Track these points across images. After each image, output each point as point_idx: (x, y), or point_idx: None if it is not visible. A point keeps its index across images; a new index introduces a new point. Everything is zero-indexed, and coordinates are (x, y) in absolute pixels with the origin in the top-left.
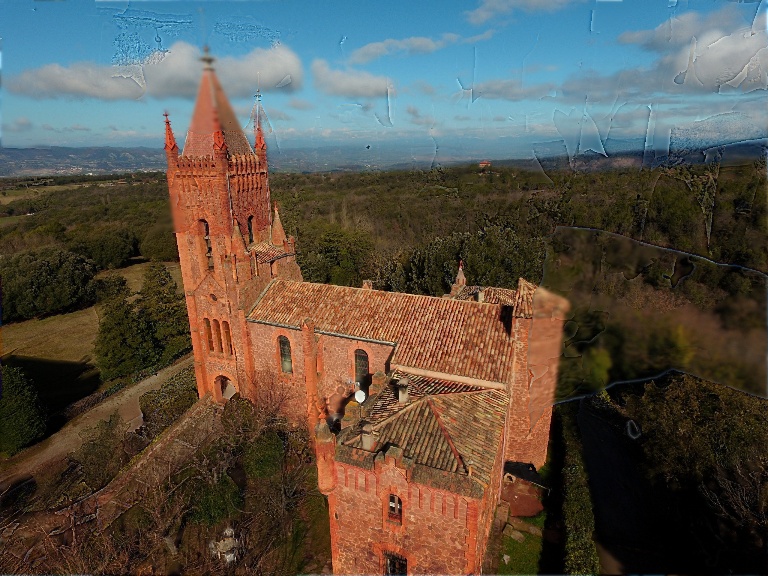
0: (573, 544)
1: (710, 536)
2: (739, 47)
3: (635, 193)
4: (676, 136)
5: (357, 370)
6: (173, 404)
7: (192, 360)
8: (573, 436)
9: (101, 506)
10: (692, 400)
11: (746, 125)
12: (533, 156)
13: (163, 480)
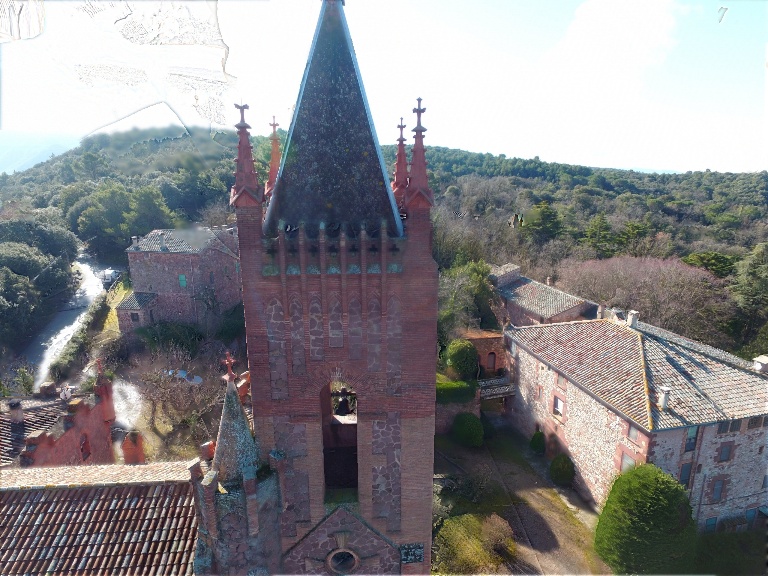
0: None
1: None
2: None
3: None
4: None
5: None
6: None
7: None
8: None
9: None
10: None
11: None
12: None
13: None
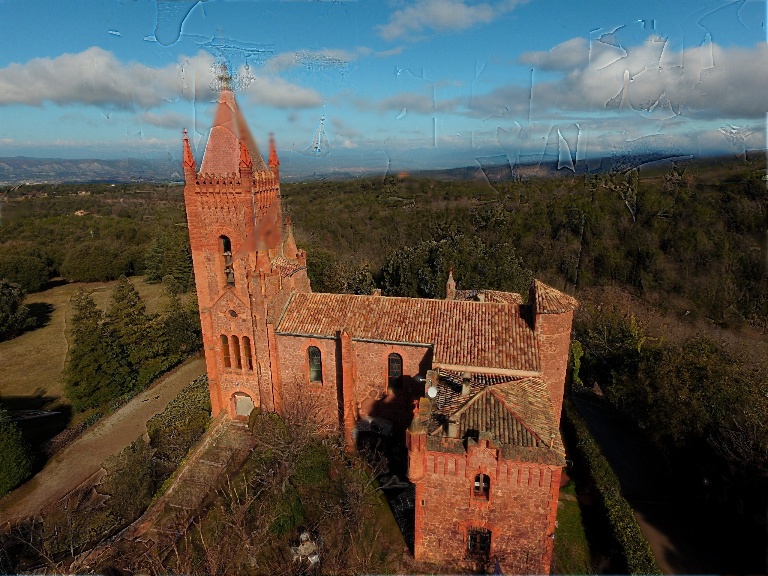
0: (610, 502)
1: (719, 478)
2: (656, 79)
3: (569, 202)
4: (613, 153)
5: (390, 373)
6: (188, 425)
7: (168, 383)
8: (576, 415)
9: (141, 536)
10: (684, 372)
11: (669, 145)
12: (475, 169)
13: (201, 501)
